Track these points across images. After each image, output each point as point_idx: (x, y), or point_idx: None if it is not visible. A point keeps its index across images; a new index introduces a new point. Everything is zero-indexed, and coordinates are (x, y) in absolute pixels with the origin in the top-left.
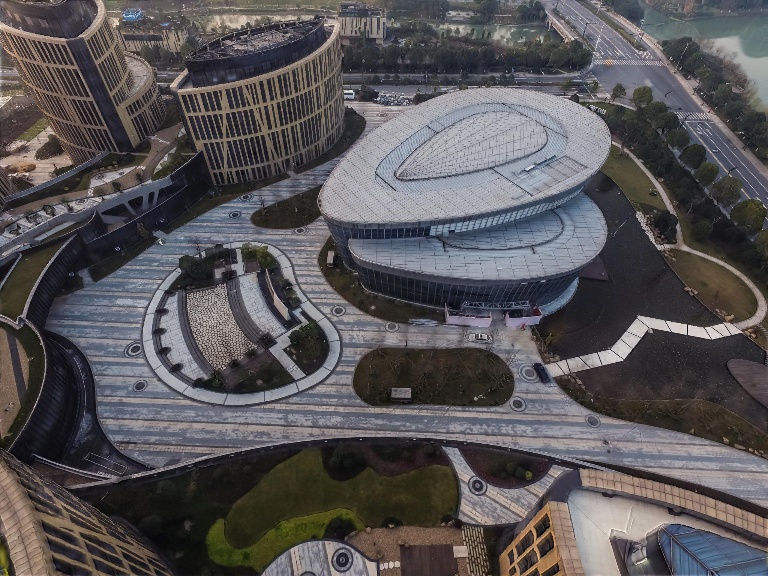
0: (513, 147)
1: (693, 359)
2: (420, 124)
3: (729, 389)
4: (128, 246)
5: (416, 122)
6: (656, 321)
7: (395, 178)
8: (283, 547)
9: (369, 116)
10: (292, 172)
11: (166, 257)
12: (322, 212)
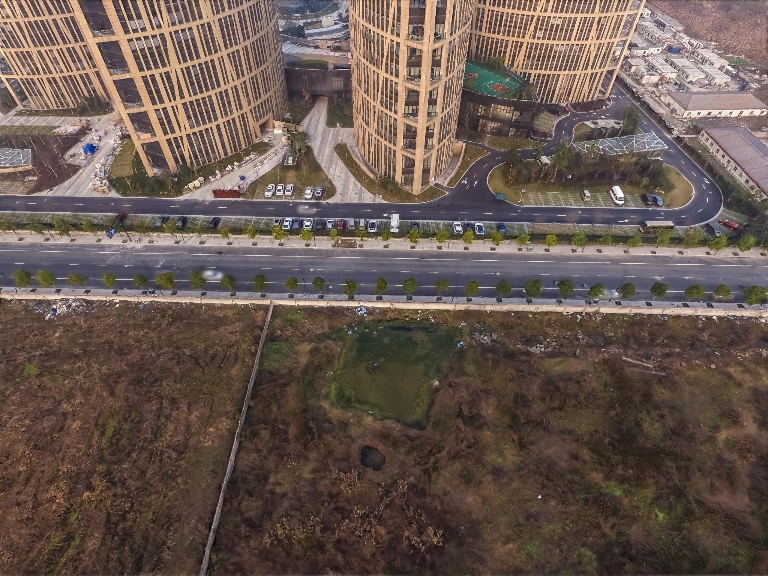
0: None
1: None
2: None
3: None
4: None
5: None
6: None
7: None
8: None
9: None
10: None
11: None
12: None
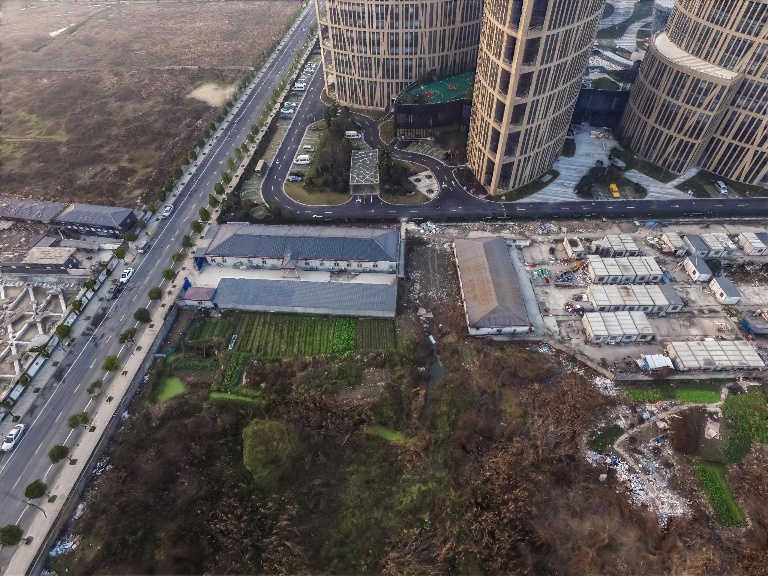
0: None
1: None
2: None
3: None
4: None
5: None
6: None
7: None
8: None
9: (611, 2)
10: None
11: None
12: (664, 7)
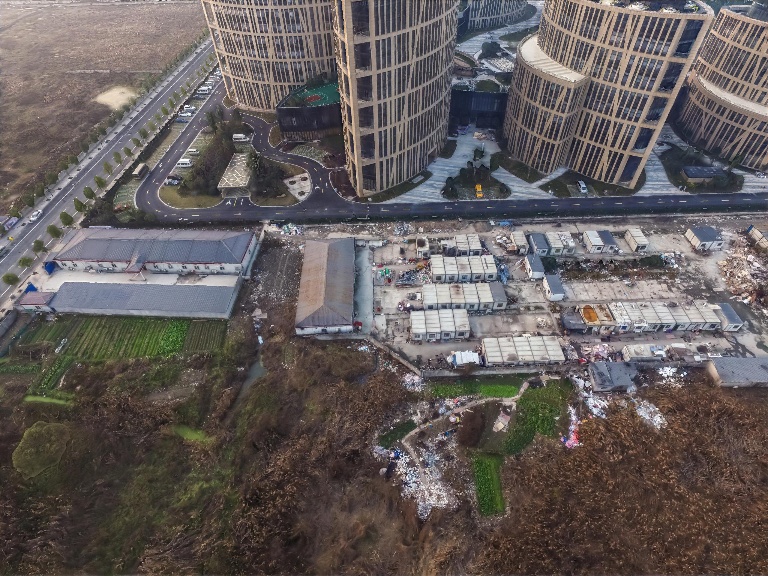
0: None
1: None
2: None
3: None
4: None
5: None
6: None
7: None
8: None
9: (536, 5)
10: (508, 24)
11: (467, 50)
12: None
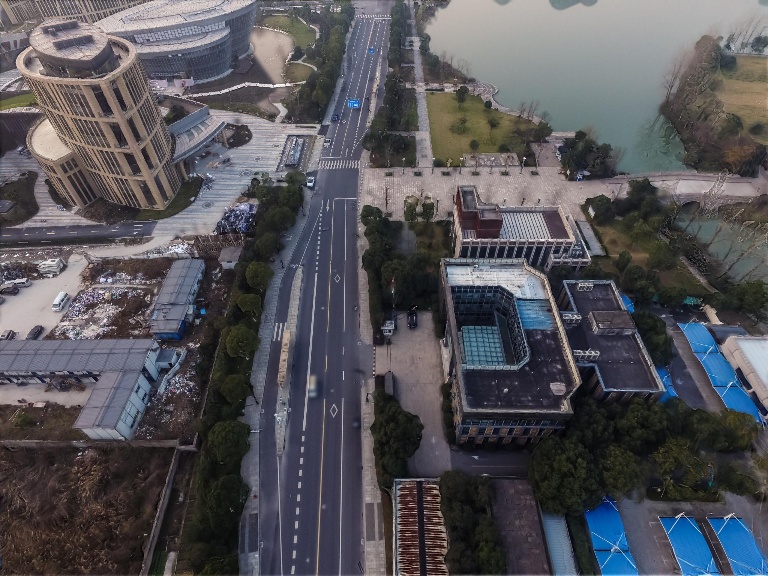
0: (199, 7)
1: (257, 93)
2: (162, 2)
3: (262, 100)
4: (2, 68)
5: (161, 2)
6: (253, 83)
7: (129, 20)
8: (8, 108)
9: None
10: None
11: None
12: None
